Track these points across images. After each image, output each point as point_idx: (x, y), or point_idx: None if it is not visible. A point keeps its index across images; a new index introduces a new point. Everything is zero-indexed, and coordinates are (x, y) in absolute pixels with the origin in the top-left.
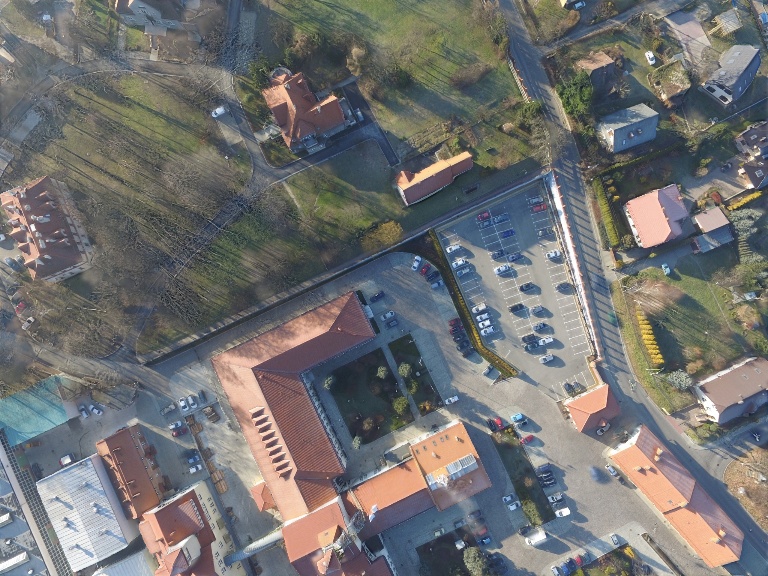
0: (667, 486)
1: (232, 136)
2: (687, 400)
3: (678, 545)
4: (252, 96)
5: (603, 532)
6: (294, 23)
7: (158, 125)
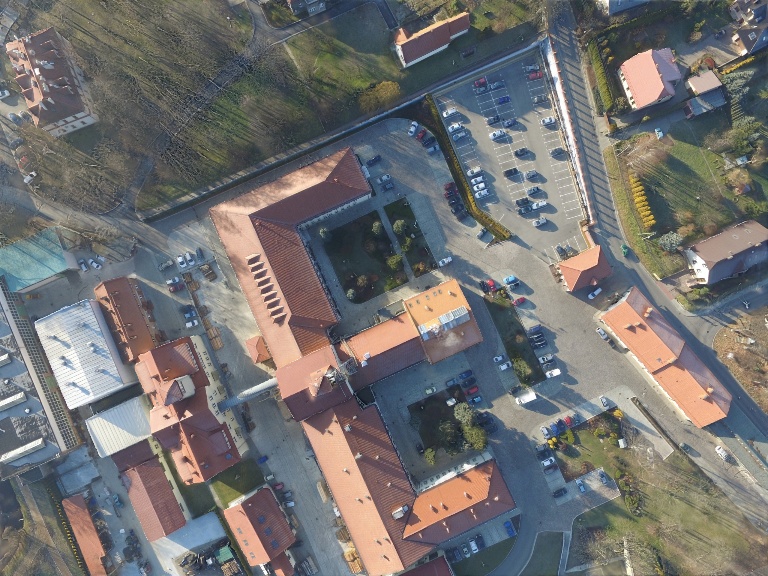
0: (656, 343)
1: None
2: (678, 265)
3: (667, 410)
4: None
5: (593, 395)
6: None
7: None
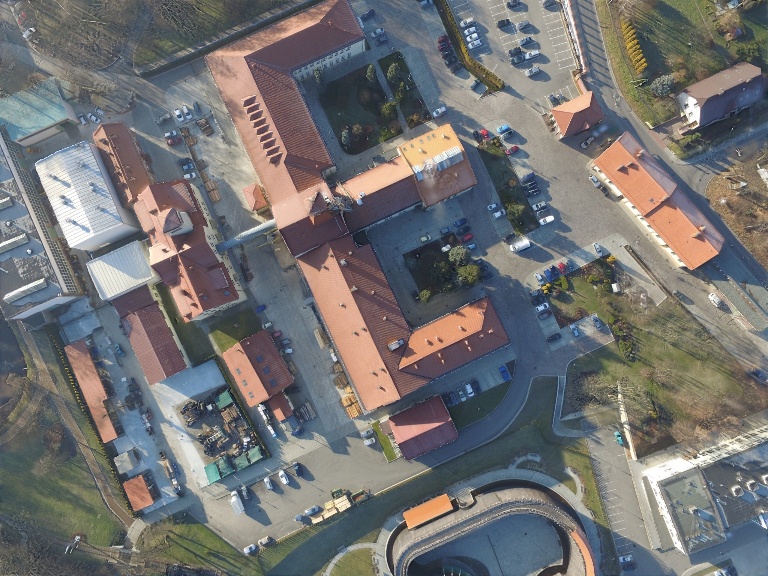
0: (648, 182)
1: None
2: (670, 112)
3: (660, 258)
4: None
5: (586, 242)
6: None
7: None
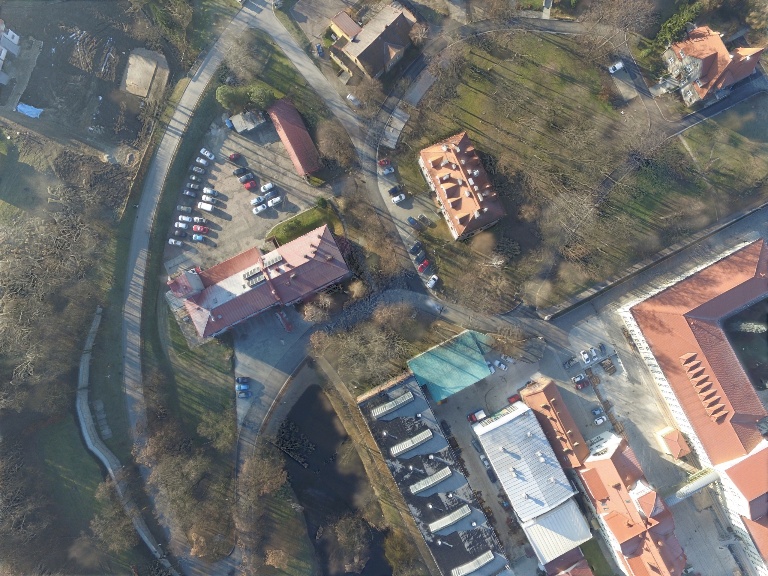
0: None
1: (627, 91)
2: None
3: None
4: None
5: None
6: None
7: (552, 82)
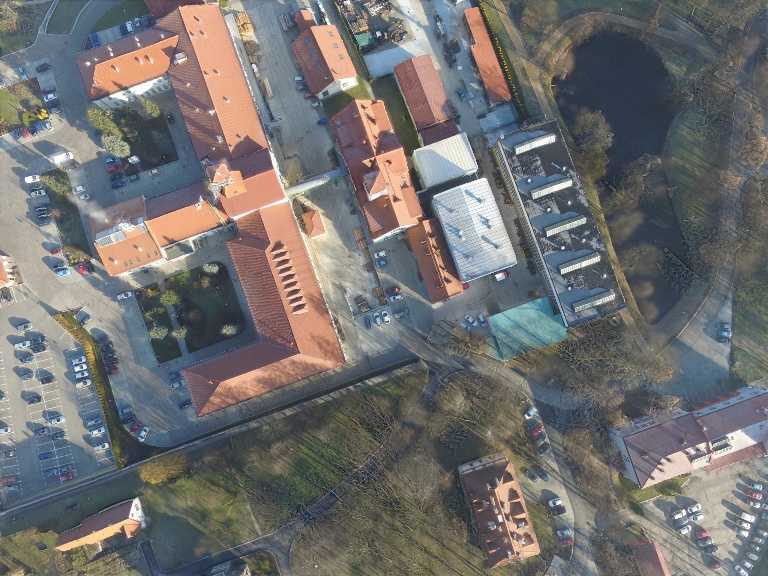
0: None
1: None
2: None
3: None
4: None
5: None
6: None
7: None
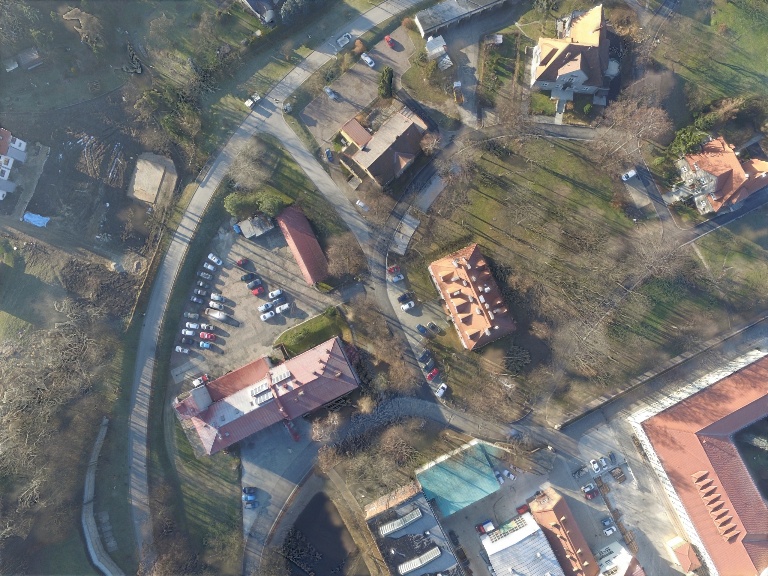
0: None
1: (640, 199)
2: None
3: None
4: (664, 159)
5: None
6: (699, 86)
7: (564, 189)
